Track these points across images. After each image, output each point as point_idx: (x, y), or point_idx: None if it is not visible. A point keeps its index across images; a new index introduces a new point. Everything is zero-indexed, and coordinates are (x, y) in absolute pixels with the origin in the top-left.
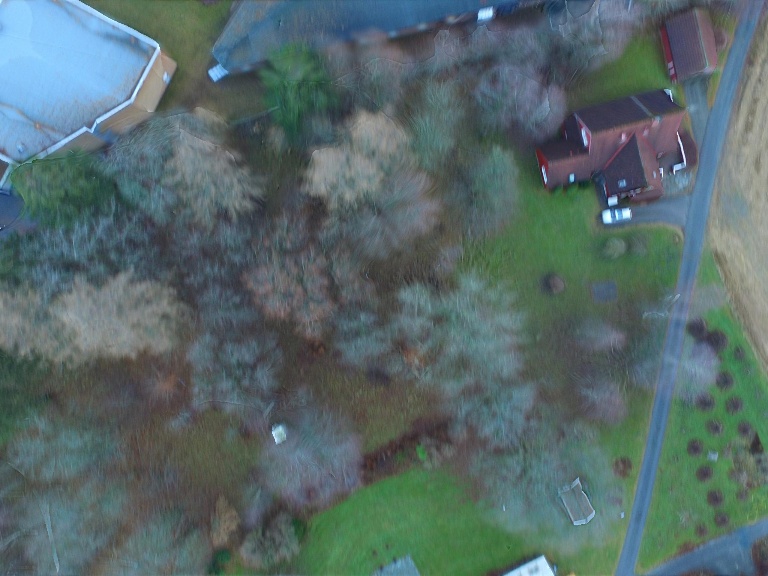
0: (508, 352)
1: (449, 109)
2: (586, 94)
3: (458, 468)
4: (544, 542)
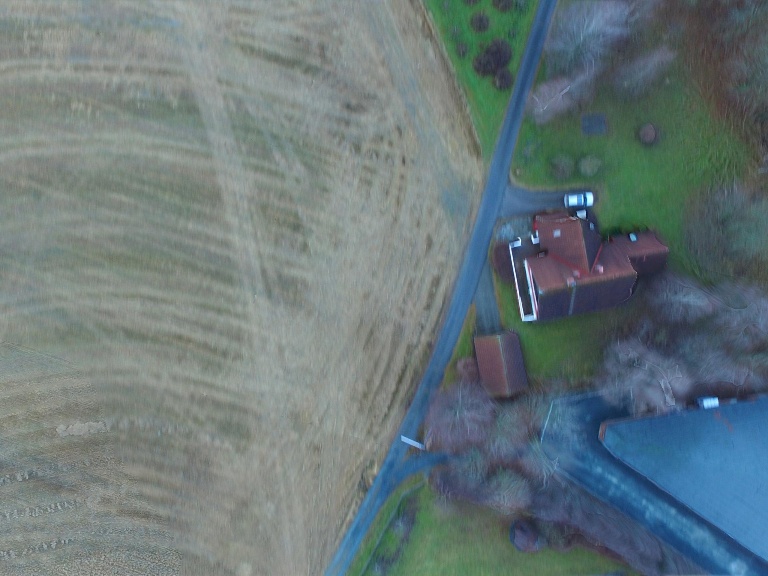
0: (696, 69)
1: None
2: (600, 323)
3: None
4: None
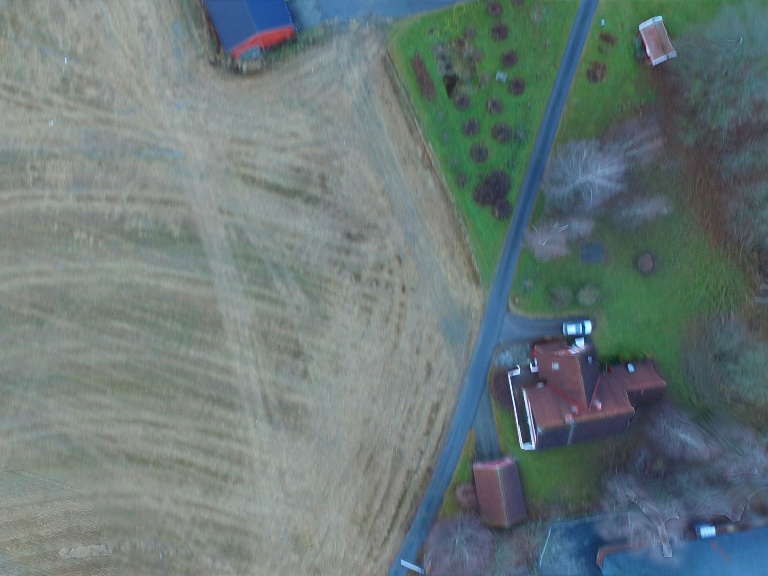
0: (694, 198)
1: (767, 442)
2: (598, 449)
3: (764, 84)
4: (685, 1)
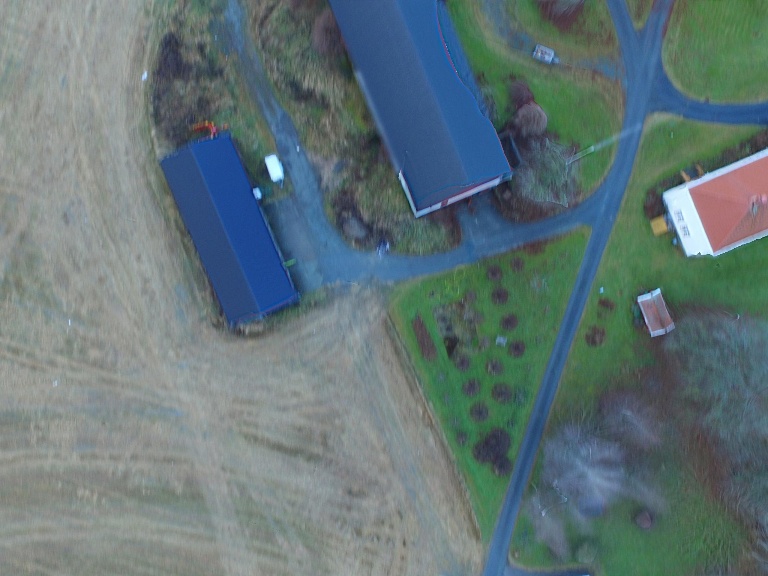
0: (691, 453)
1: None
2: None
3: (761, 348)
4: (683, 268)
